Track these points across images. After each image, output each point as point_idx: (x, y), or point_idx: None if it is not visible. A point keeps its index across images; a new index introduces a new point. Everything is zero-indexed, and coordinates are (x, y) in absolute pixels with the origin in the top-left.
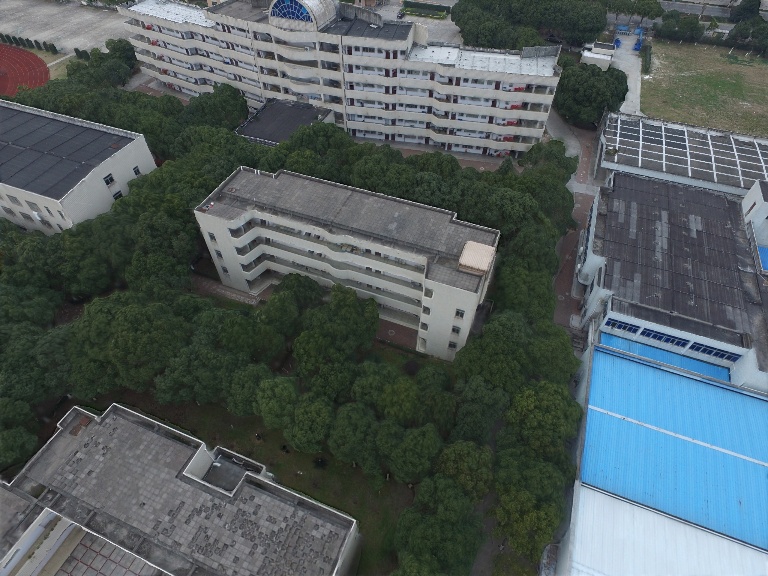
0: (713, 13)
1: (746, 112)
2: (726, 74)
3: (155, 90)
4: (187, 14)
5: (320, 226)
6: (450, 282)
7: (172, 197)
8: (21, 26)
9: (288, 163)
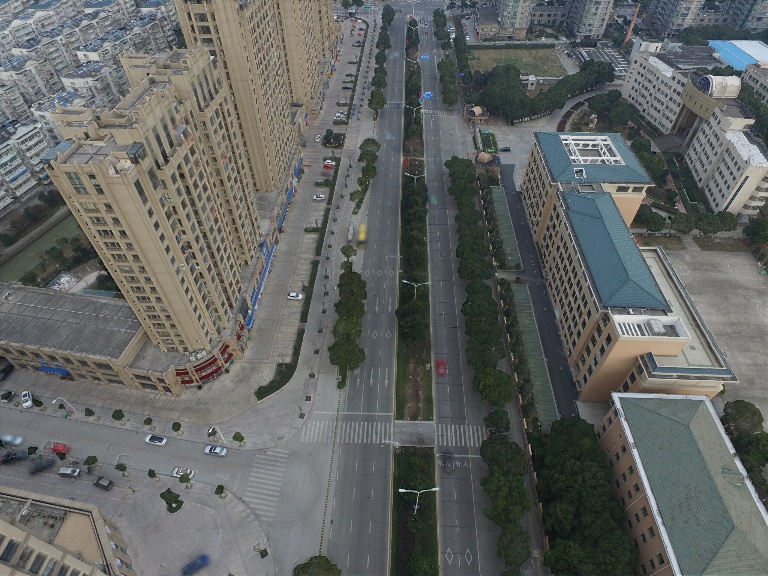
0: (400, 60)
1: None
2: (496, 61)
3: (749, 216)
4: (744, 147)
5: None
6: None
7: None
8: None
9: (767, 107)
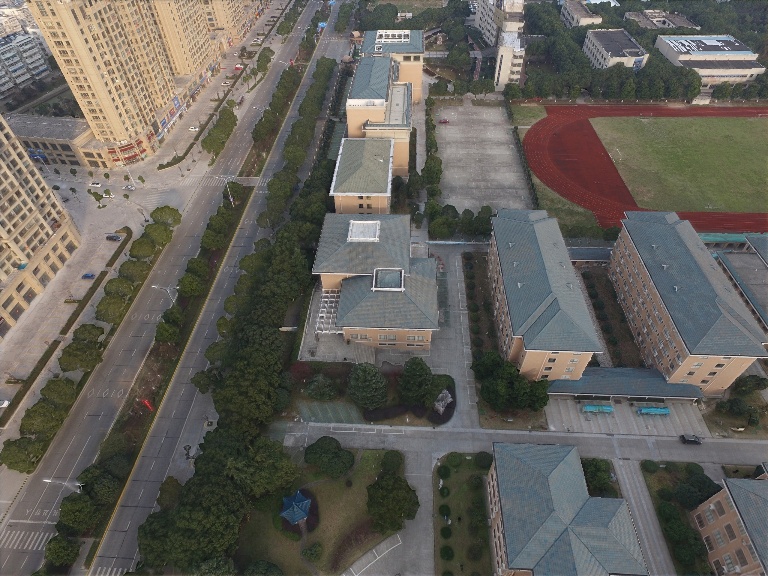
0: None
1: (423, 5)
2: None
3: None
4: (511, 40)
5: (585, 11)
6: (584, 0)
7: (601, 23)
8: (493, 168)
9: None
